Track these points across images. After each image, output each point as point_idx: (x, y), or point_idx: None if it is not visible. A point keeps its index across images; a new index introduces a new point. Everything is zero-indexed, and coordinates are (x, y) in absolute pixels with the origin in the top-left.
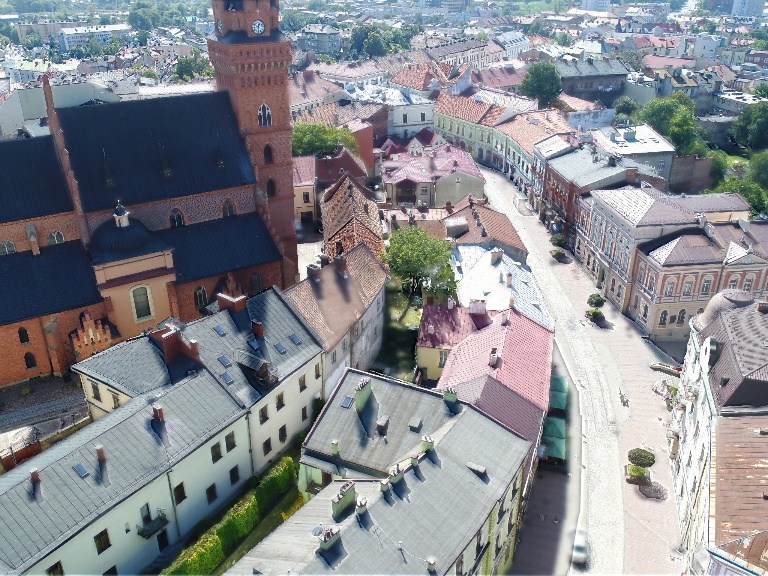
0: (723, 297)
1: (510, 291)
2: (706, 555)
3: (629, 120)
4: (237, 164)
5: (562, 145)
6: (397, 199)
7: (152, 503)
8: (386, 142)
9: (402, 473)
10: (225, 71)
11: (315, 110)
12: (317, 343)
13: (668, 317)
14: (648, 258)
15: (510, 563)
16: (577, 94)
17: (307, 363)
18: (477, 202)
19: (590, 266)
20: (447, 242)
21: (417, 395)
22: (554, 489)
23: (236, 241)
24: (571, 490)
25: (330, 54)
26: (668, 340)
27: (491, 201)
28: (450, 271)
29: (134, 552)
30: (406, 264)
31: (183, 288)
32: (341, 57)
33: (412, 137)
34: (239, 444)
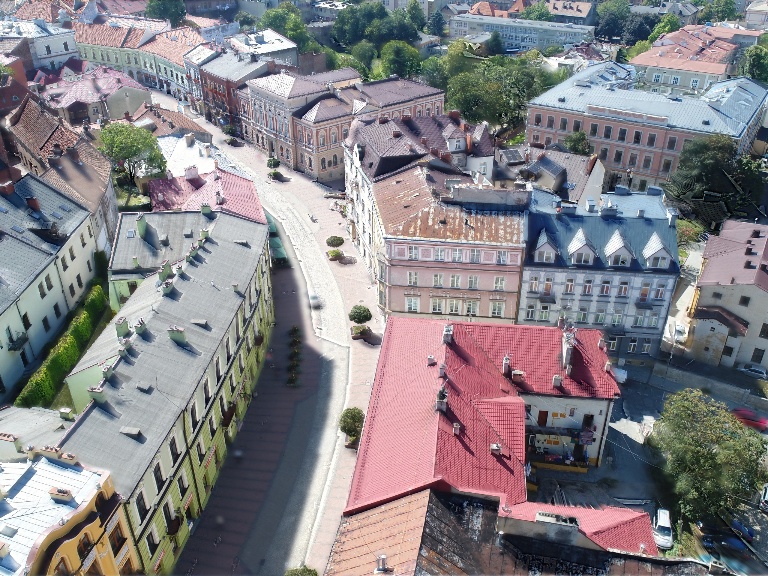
0: (358, 121)
1: (211, 159)
2: (384, 249)
3: None
4: None
5: (208, 52)
6: (72, 122)
7: (11, 327)
8: (37, 74)
9: (196, 250)
10: None
11: None
12: (84, 209)
13: (326, 162)
14: (302, 121)
15: (274, 319)
16: (200, 15)
17: (83, 222)
18: None
19: (260, 143)
20: None
21: (182, 216)
22: (286, 277)
23: None
24: (297, 275)
25: None
26: (331, 180)
27: None
28: (160, 152)
29: (9, 365)
30: (123, 151)
31: None
32: None
33: (60, 67)
34: (55, 285)
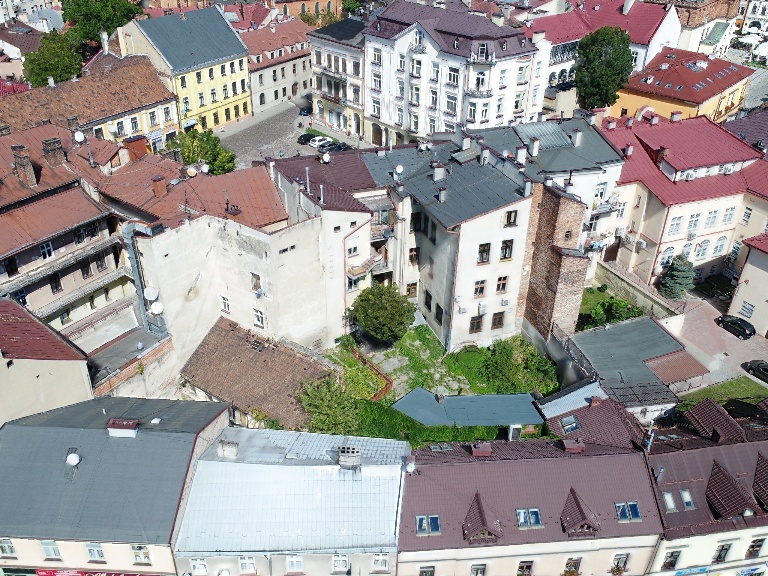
0: None
1: None
2: None
3: None
4: None
5: None
6: None
7: None
8: None
9: None
10: None
11: None
12: None
13: None
14: None
15: None
16: None
17: None
18: None
19: None
20: None
21: None
22: None
23: None
24: None
25: None
26: None
27: None
28: None
29: None
30: None
31: None
32: None
33: None
34: None
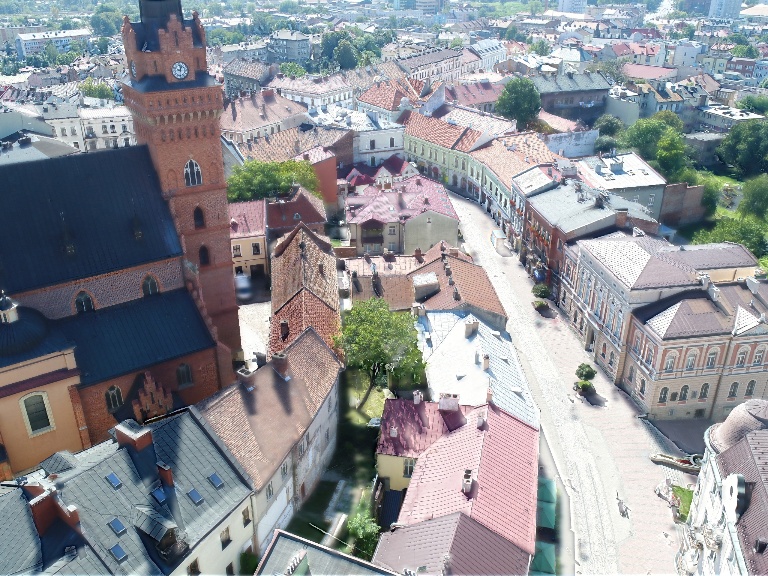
0: (747, 413)
1: (487, 377)
2: None
3: (613, 143)
4: (159, 233)
5: (543, 180)
6: (362, 240)
7: None
8: (351, 172)
9: None
10: (143, 122)
11: (273, 137)
12: (244, 483)
13: (668, 394)
14: (645, 328)
15: None
16: (557, 110)
17: (230, 515)
18: (450, 251)
19: (577, 324)
20: (414, 309)
21: (366, 575)
22: None
23: (159, 326)
24: None
25: (300, 61)
26: (668, 419)
27: (466, 238)
28: (416, 355)
29: None
30: (363, 351)
31: (90, 391)
32: (311, 65)
33: (380, 164)
34: None
